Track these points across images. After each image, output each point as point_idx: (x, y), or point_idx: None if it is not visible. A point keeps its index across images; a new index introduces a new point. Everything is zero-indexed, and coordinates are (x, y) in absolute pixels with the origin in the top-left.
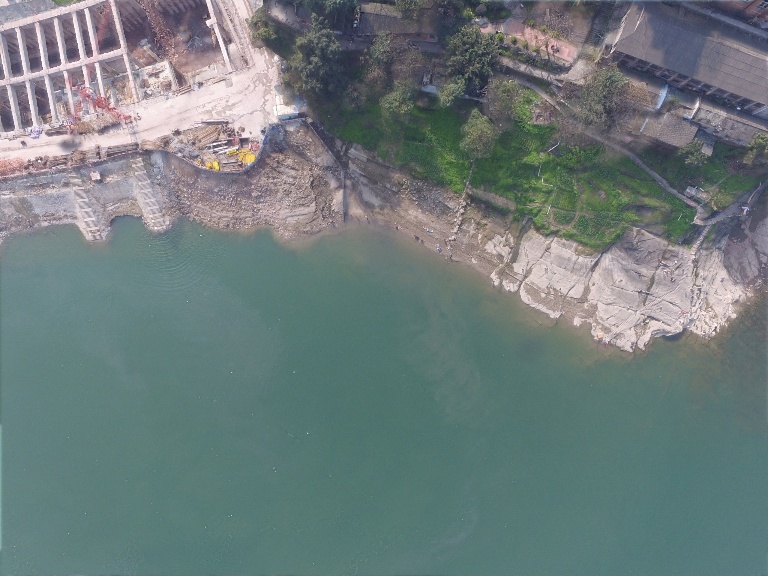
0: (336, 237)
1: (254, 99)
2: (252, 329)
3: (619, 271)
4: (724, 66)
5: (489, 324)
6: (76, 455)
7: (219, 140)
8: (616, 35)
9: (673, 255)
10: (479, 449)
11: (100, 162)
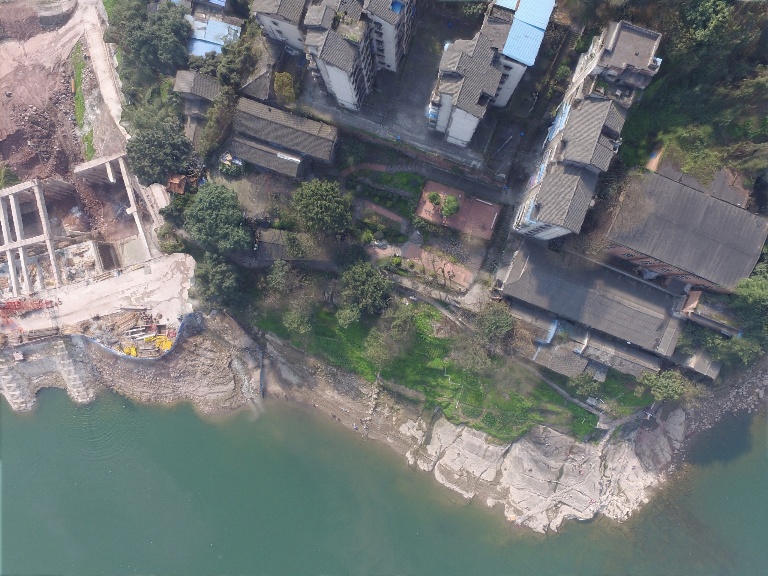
0: (255, 413)
1: (172, 286)
2: (172, 501)
3: (529, 461)
4: (607, 315)
5: (404, 501)
6: None
7: (137, 326)
8: (506, 272)
9: (580, 451)
10: None
11: (22, 344)
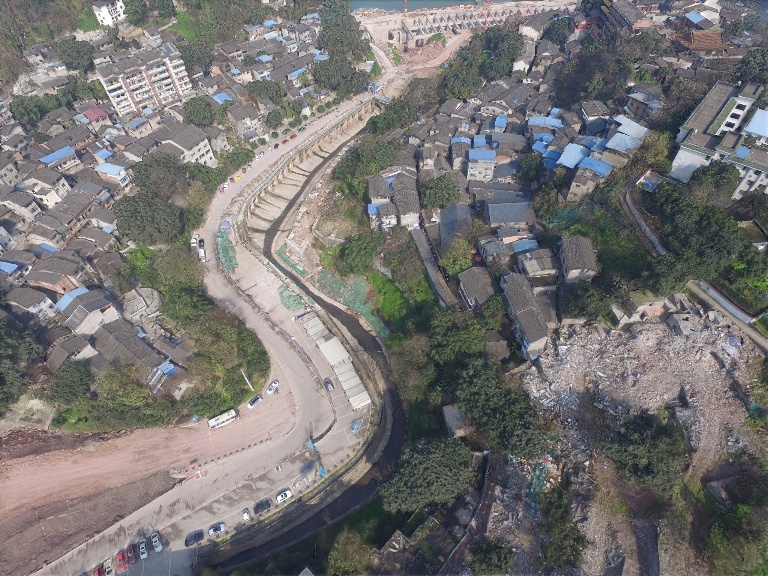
0: None
1: None
2: None
3: None
4: None
5: None
6: None
7: None
8: None
9: None
10: None
11: None
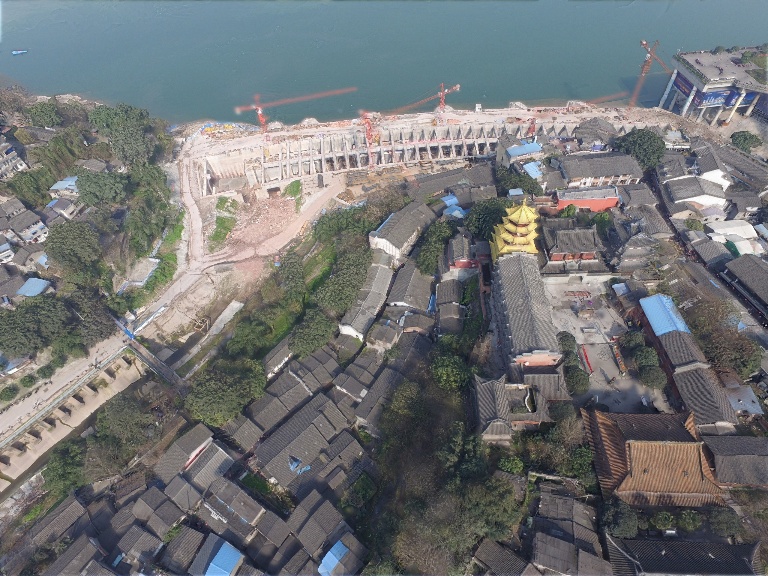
0: None
1: None
2: None
3: None
4: None
5: (127, 101)
6: None
7: None
8: None
9: None
10: None
11: None
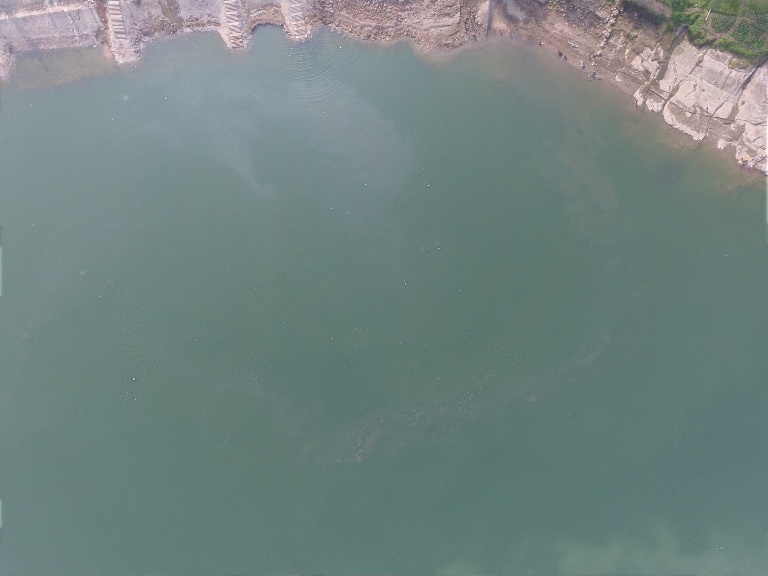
0: (477, 51)
1: None
2: (388, 141)
3: None
4: None
5: (629, 146)
6: (208, 261)
7: None
8: None
9: None
10: (613, 270)
11: None
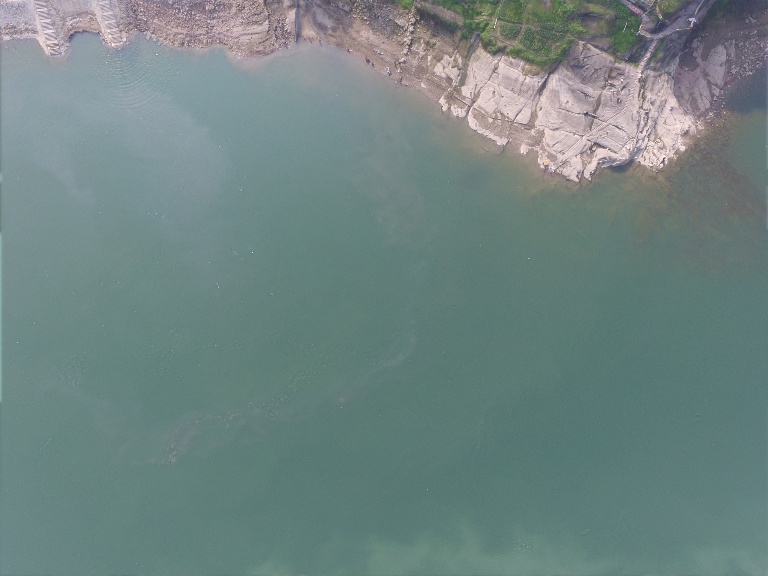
0: (288, 58)
1: None
2: (202, 147)
3: (566, 92)
4: None
5: (436, 151)
6: (27, 265)
7: None
8: None
9: (619, 73)
10: (420, 273)
11: None
